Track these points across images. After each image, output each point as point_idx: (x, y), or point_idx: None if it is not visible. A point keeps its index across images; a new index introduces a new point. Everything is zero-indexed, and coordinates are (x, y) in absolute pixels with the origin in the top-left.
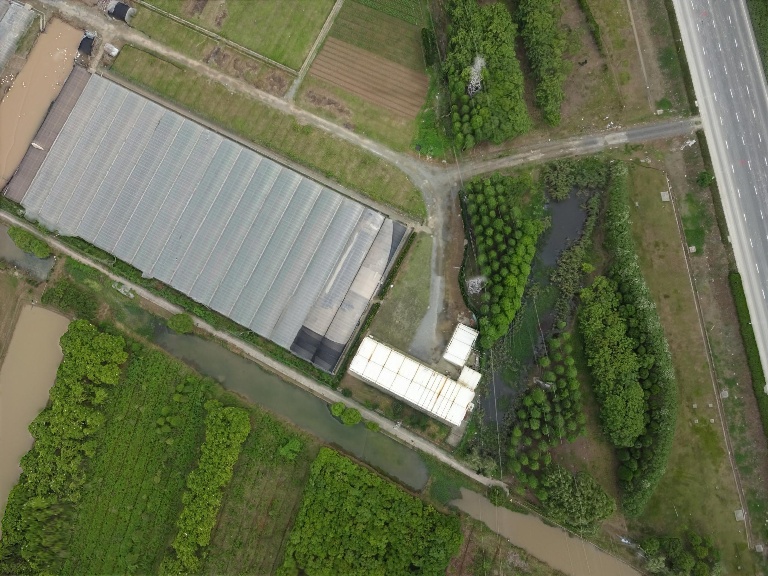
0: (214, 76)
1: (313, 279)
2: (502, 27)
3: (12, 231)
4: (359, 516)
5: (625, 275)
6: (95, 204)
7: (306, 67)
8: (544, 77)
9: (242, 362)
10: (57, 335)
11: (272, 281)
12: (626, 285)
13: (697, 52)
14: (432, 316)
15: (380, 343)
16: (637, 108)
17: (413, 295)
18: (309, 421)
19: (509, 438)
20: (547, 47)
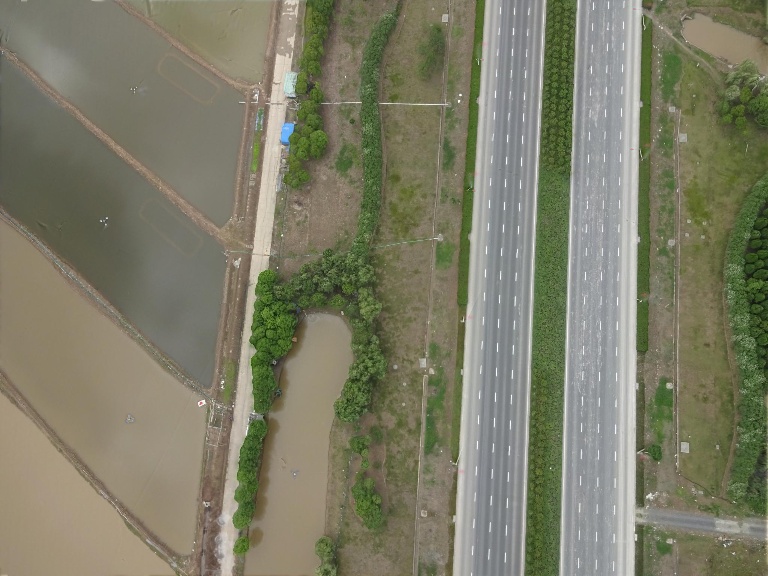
0: None
1: None
2: None
3: None
4: None
5: (761, 376)
6: None
7: None
8: None
9: None
10: None
11: None
12: None
13: None
14: None
15: None
16: (693, 554)
17: None
18: None
19: None
20: None
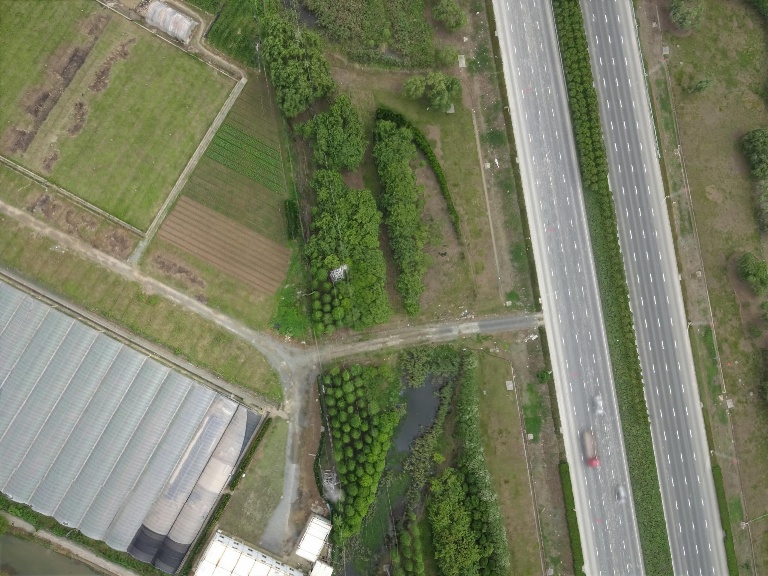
0: (41, 229)
1: (156, 474)
2: (367, 217)
3: None
4: None
5: (471, 467)
6: None
7: (154, 228)
8: (406, 271)
9: (68, 563)
10: None
11: (107, 475)
12: (472, 479)
13: (543, 251)
14: (285, 506)
15: (229, 546)
16: (489, 298)
17: (266, 484)
18: None
19: None
20: (410, 240)
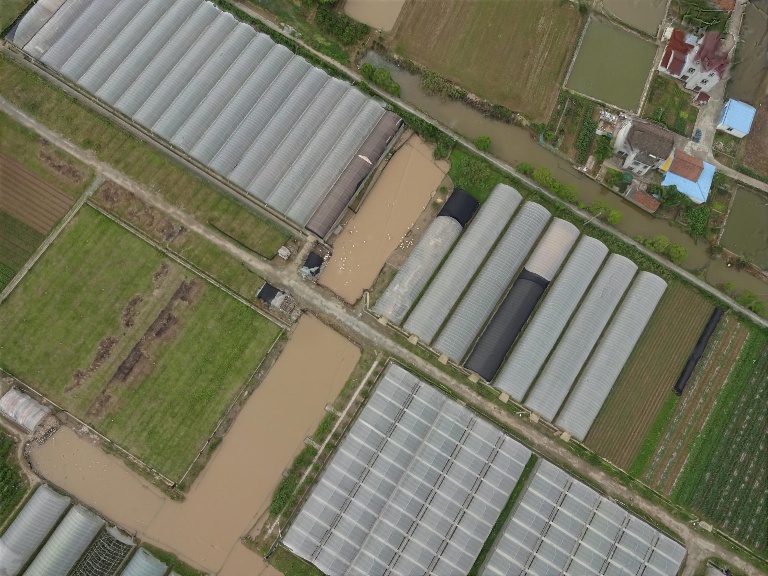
0: (176, 212)
1: (99, 4)
2: None
3: (393, 85)
4: None
5: None
6: (305, 96)
7: (77, 207)
8: None
9: None
10: (359, 4)
11: None
12: None
13: None
14: None
15: None
16: None
17: None
18: None
19: None
20: None
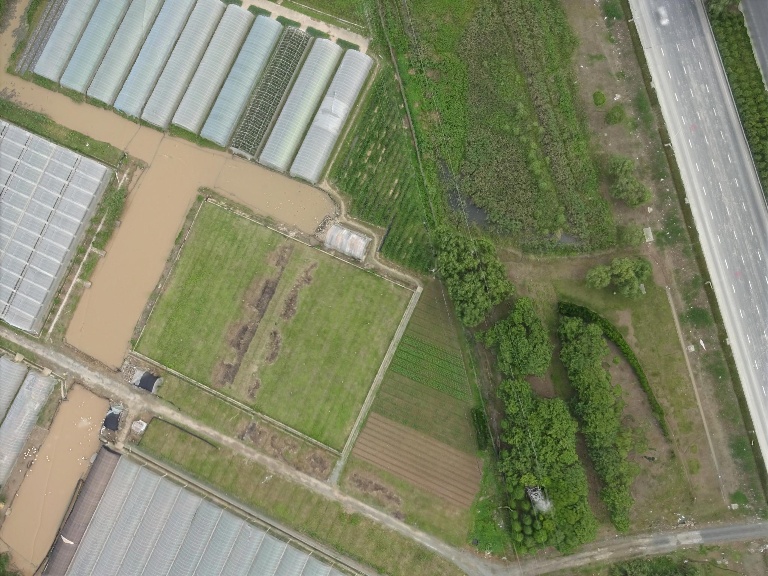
0: (251, 455)
1: None
2: (562, 432)
3: None
4: None
5: None
6: None
7: (349, 446)
8: (610, 485)
9: None
10: None
11: None
12: None
13: None
14: None
15: None
16: (709, 501)
17: None
18: None
19: None
20: (612, 452)
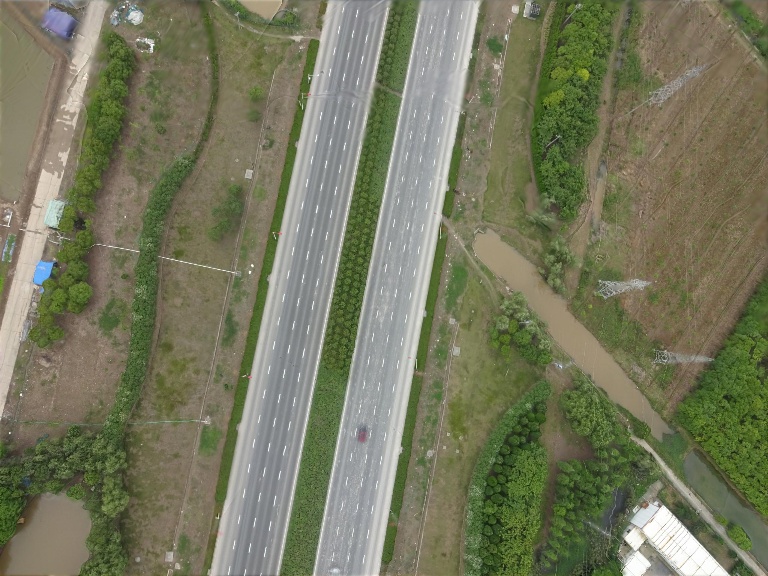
0: None
1: None
2: None
3: None
4: (761, 456)
5: None
6: None
7: None
8: None
9: None
10: None
11: None
12: None
13: None
14: None
15: None
16: None
17: None
18: (765, 537)
19: (615, 473)
20: None
